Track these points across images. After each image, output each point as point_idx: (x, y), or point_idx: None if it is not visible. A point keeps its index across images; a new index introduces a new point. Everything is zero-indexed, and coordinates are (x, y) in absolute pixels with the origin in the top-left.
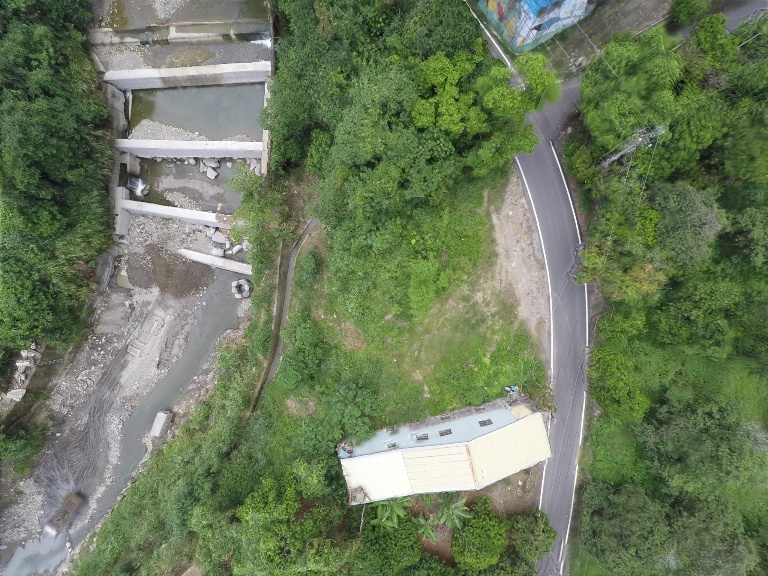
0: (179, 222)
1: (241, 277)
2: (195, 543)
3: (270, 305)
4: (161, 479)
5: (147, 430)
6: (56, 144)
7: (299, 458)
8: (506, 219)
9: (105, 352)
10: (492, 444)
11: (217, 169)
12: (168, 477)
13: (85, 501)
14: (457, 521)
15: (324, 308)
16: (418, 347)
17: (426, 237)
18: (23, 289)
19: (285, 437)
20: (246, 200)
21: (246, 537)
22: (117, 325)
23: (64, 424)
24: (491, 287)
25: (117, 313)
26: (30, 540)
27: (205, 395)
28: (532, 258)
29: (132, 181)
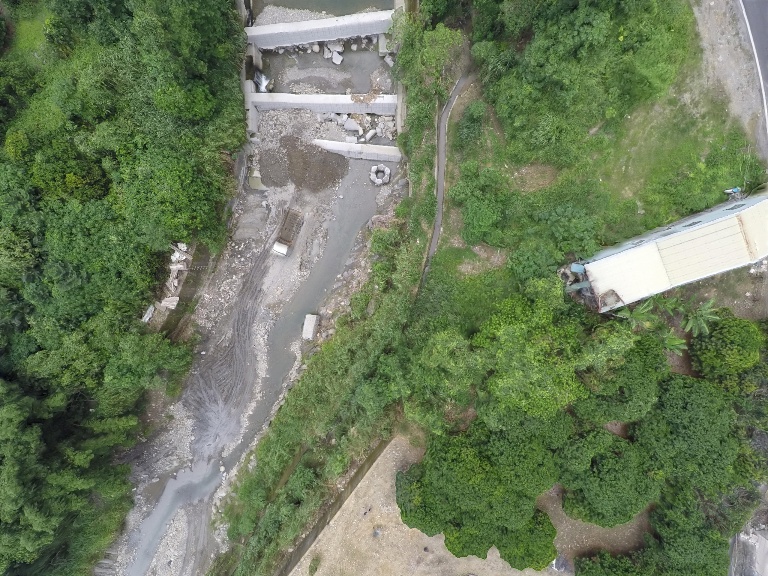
0: (310, 112)
1: (377, 164)
2: (394, 414)
3: (432, 168)
4: (325, 376)
5: (294, 337)
6: (212, 7)
7: (531, 277)
8: (708, 11)
9: (245, 259)
10: (760, 215)
11: (341, 55)
12: (332, 373)
13: (236, 420)
14: (705, 325)
15: (492, 161)
16: (625, 162)
17: (640, 26)
18: (186, 171)
19: (483, 285)
20: (405, 52)
21: (503, 351)
22: (255, 228)
23: (208, 342)
24: (698, 86)
25: (256, 214)
26: (182, 470)
27: (358, 286)
28: (738, 50)
29: (257, 75)
